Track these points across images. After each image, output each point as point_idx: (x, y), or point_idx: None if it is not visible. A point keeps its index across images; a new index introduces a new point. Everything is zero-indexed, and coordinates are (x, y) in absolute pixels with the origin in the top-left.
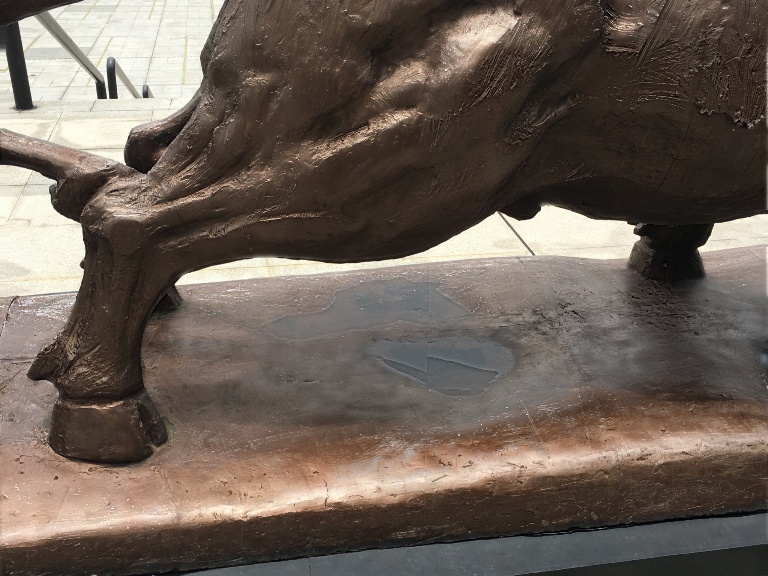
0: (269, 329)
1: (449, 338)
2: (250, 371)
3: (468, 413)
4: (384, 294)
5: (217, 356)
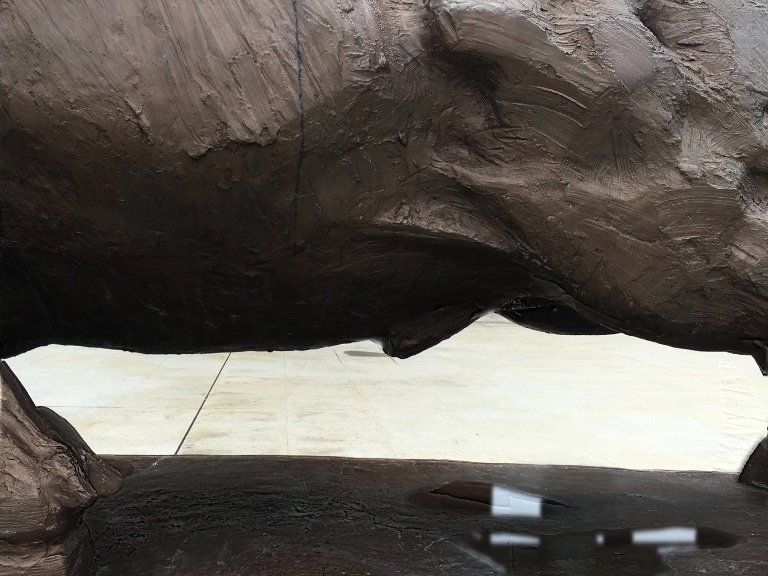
0: (733, 535)
1: (483, 516)
2: (712, 506)
3: (469, 471)
4: (590, 568)
5: (767, 516)
